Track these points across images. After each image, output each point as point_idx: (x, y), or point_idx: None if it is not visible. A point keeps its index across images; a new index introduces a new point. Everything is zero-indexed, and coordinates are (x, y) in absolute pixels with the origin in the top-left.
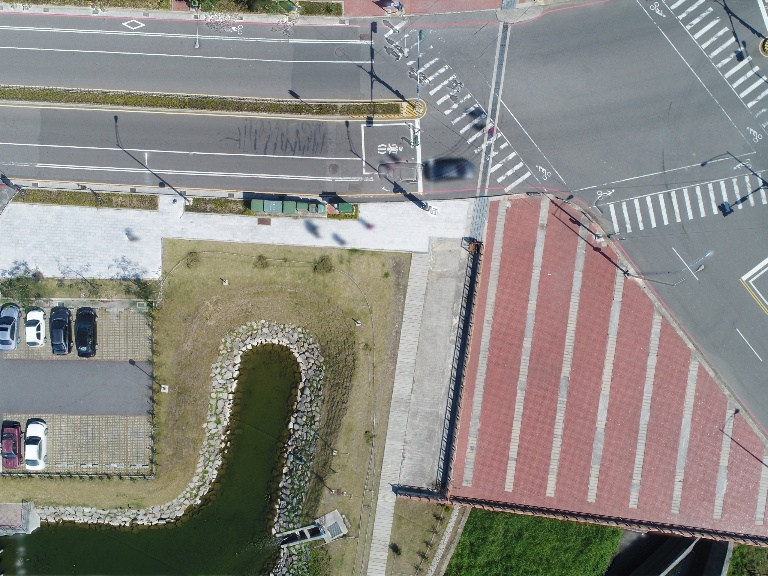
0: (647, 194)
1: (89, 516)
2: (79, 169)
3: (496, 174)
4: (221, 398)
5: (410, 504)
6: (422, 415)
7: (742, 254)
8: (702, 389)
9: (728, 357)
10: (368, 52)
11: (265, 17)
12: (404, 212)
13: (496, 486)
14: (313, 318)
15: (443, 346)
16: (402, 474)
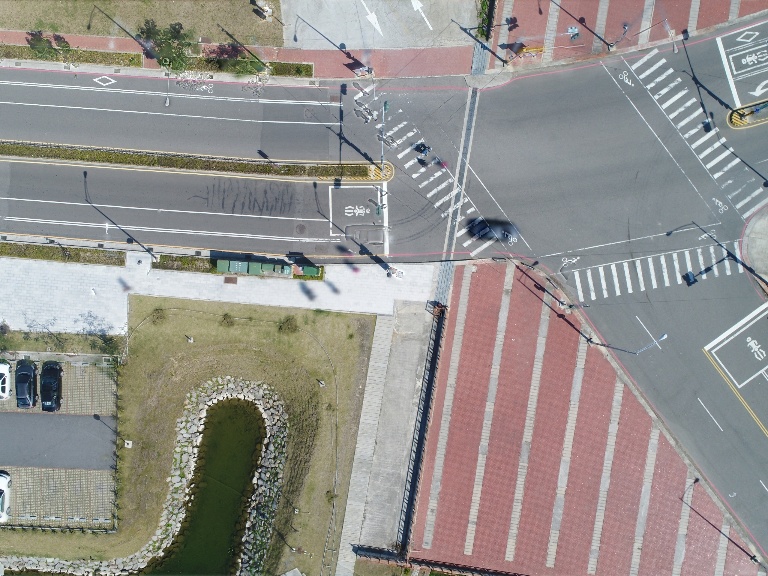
0: (612, 262)
1: (52, 566)
2: (48, 223)
3: (462, 238)
4: (186, 452)
5: (370, 564)
6: (384, 476)
7: (705, 324)
8: (662, 457)
9: (689, 426)
10: (337, 114)
11: (236, 76)
12: (370, 274)
13: (456, 549)
14: (278, 376)
15: (406, 408)
16: (363, 534)
